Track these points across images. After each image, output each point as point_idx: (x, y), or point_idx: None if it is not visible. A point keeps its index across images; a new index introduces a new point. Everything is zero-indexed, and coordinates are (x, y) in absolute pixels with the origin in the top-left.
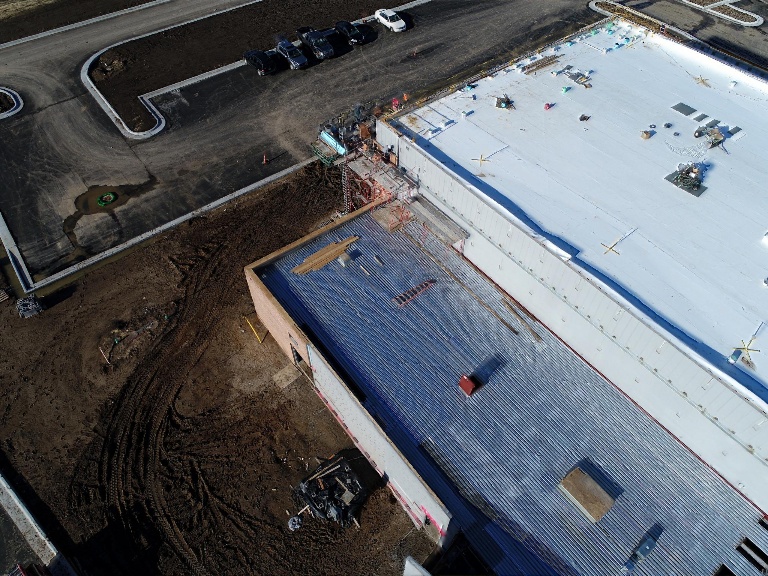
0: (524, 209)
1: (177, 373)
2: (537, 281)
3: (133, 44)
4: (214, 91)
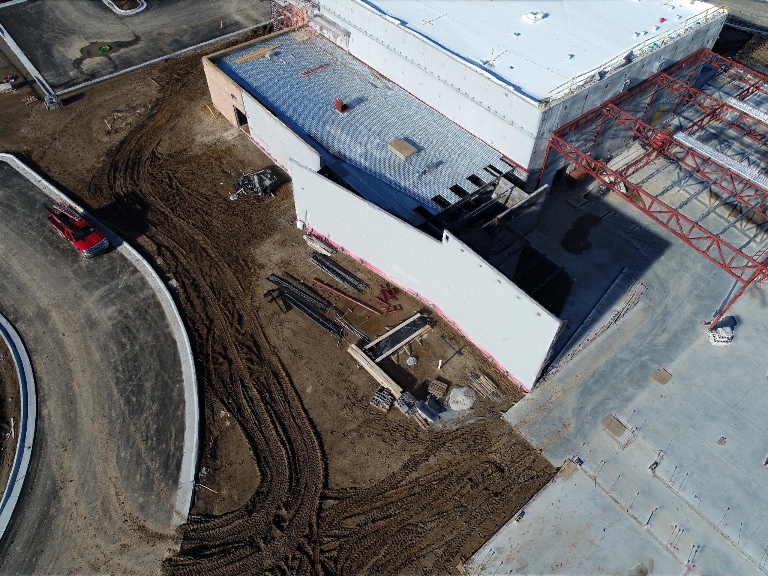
0: (379, 6)
1: (158, 134)
2: (386, 48)
3: None
4: None
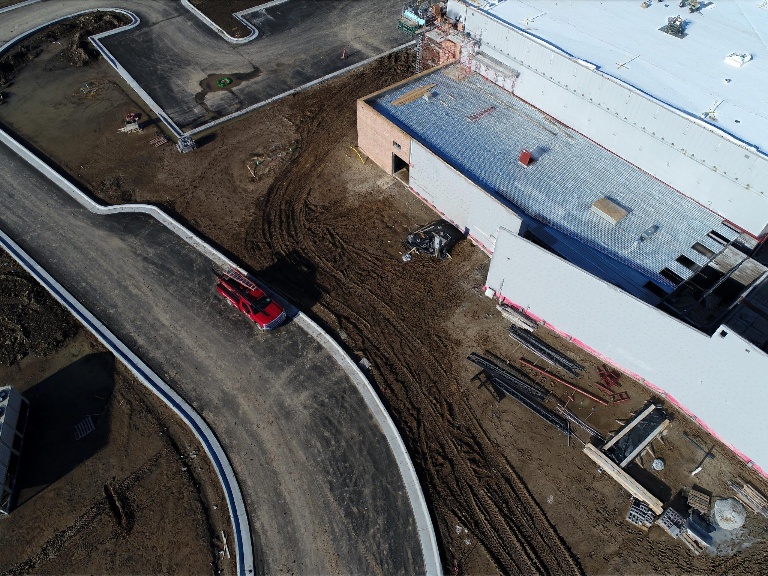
0: (561, 46)
1: (306, 182)
2: (571, 93)
3: None
4: (293, 10)
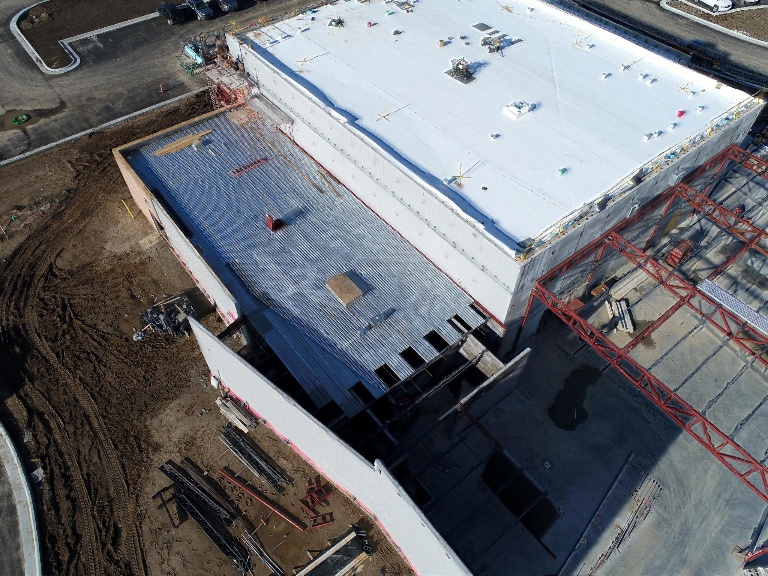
0: (326, 93)
1: (61, 240)
2: (332, 147)
3: (60, 0)
4: (127, 37)
